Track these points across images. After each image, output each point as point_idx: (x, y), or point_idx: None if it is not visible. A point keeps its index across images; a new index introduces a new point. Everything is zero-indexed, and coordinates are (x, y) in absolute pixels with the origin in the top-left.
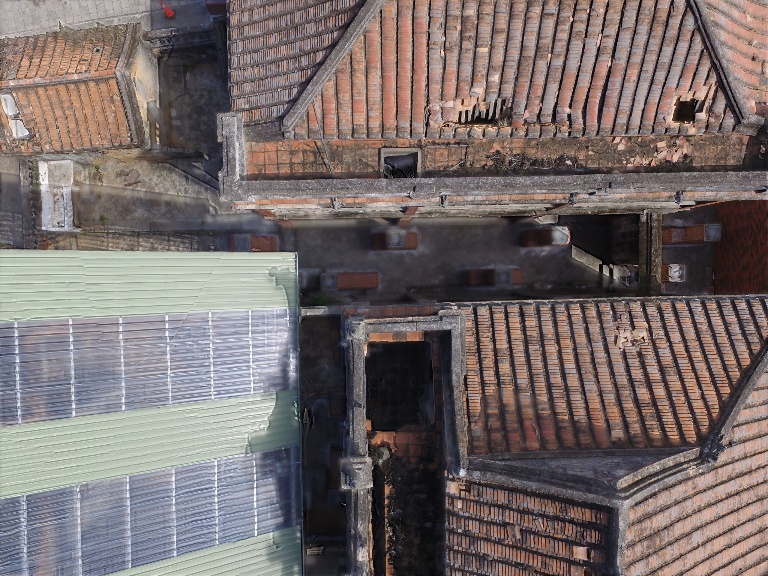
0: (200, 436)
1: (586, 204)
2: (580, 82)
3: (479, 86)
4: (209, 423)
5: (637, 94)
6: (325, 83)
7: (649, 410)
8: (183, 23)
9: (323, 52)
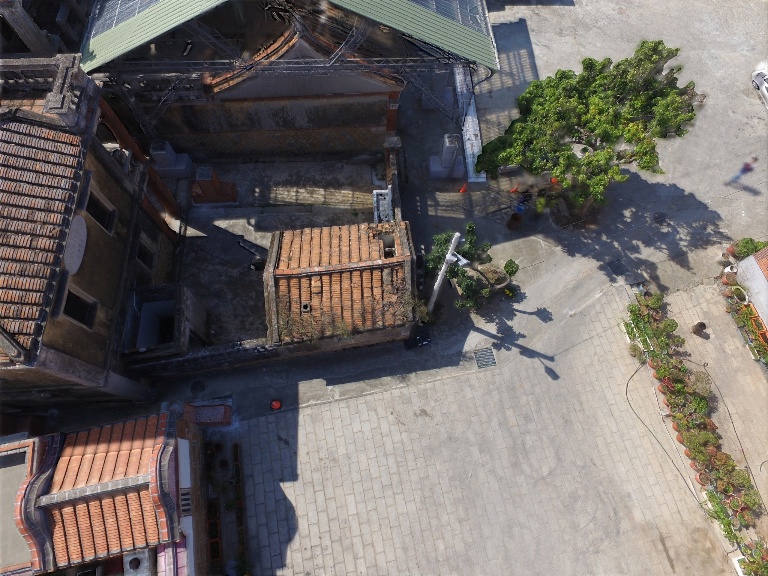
0: None
1: None
2: None
3: None
4: None
5: None
6: None
7: None
8: (263, 396)
9: None
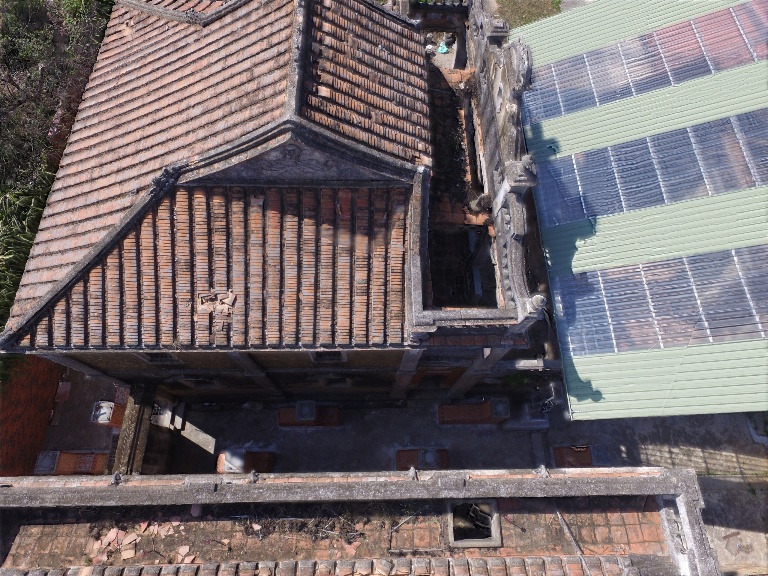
0: (646, 232)
1: None
2: None
3: None
4: (639, 243)
5: None
6: None
7: (218, 224)
8: None
9: None
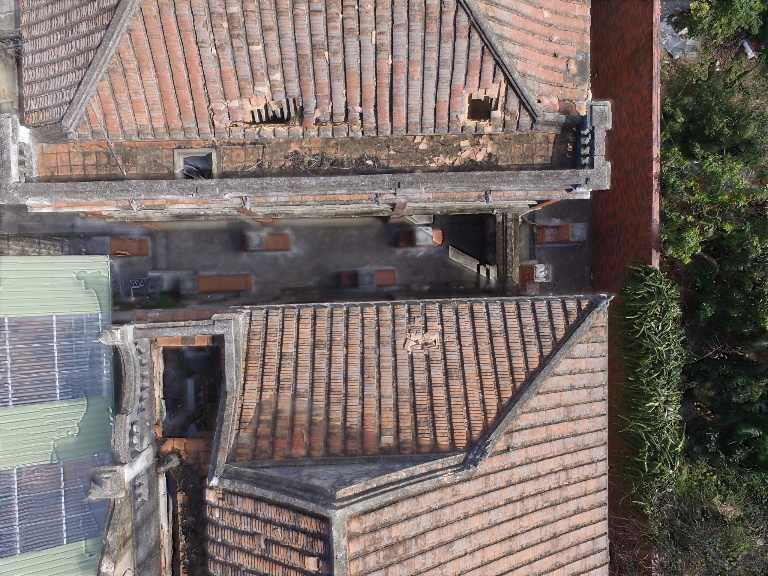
0: None
1: (425, 204)
2: (364, 80)
3: (261, 85)
4: (7, 430)
5: (425, 92)
6: (99, 83)
7: (424, 415)
8: None
9: (94, 51)
